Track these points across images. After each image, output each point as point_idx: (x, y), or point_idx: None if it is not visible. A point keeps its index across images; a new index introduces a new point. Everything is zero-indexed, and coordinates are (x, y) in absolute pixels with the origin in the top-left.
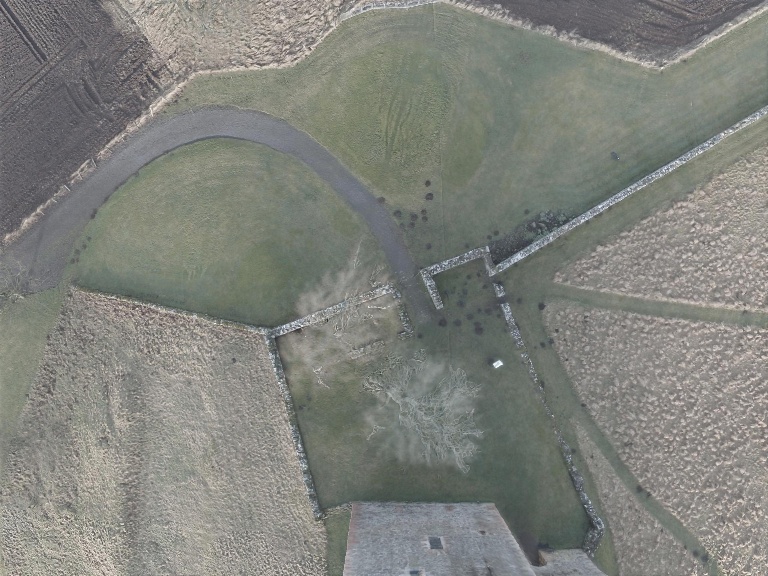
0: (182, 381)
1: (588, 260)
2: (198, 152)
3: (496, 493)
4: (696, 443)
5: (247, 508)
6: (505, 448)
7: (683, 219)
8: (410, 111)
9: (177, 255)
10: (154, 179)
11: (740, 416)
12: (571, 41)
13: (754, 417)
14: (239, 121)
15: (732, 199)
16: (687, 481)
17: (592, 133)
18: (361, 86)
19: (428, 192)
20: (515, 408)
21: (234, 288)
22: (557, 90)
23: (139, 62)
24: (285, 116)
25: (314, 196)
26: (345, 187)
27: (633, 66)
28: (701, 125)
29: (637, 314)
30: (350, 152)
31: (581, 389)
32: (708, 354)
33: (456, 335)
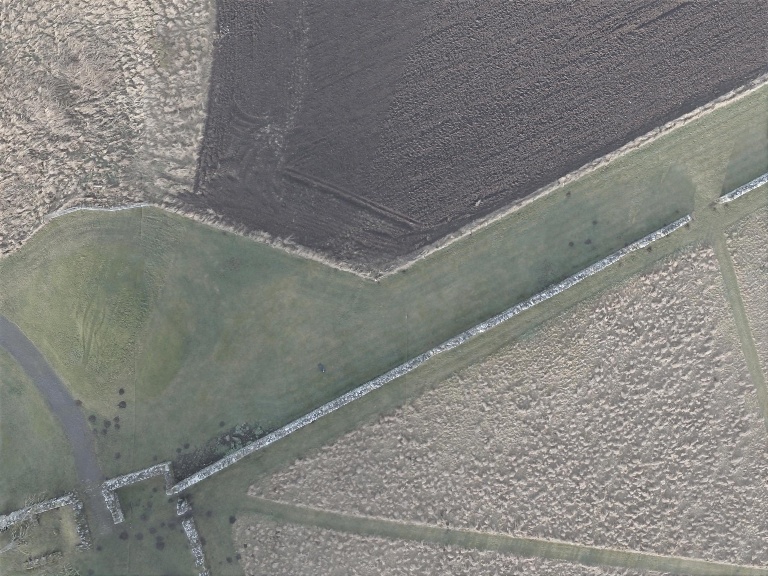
0: None
1: (286, 473)
2: None
3: None
4: None
5: None
6: None
7: (390, 433)
8: (103, 320)
9: None
10: None
11: None
12: (284, 249)
13: None
14: None
15: (442, 415)
16: None
17: (300, 343)
18: (63, 288)
19: (121, 400)
20: None
21: None
22: (266, 299)
23: None
24: None
25: (19, 390)
26: (47, 385)
27: (349, 275)
28: (414, 339)
29: (332, 531)
30: (52, 351)
31: None
32: (404, 574)
33: (137, 549)
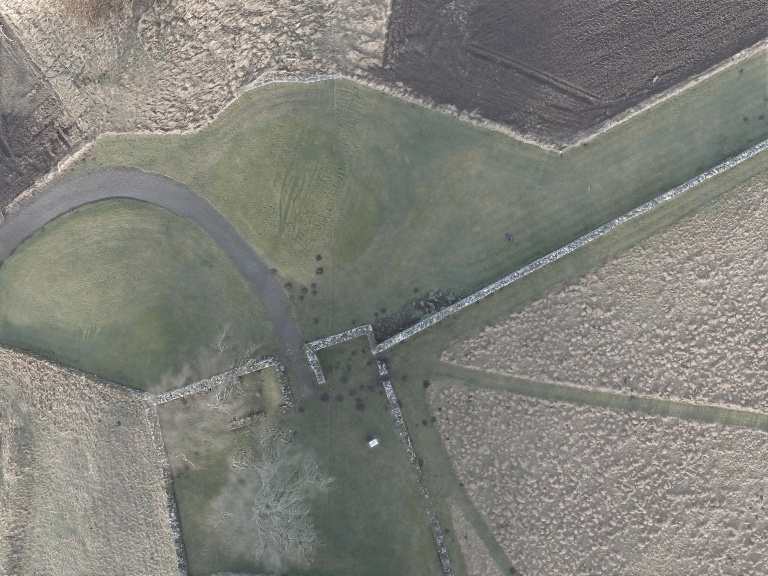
0: (71, 439)
1: (476, 340)
2: (101, 212)
3: (364, 571)
4: (573, 527)
5: (121, 571)
6: (376, 526)
7: (575, 302)
8: (303, 187)
9: (74, 313)
10: (58, 235)
11: (620, 501)
12: (471, 121)
13: (634, 503)
14: (142, 183)
15: (625, 284)
16: (562, 565)
17: (487, 213)
18: (258, 158)
19: (318, 266)
20: (390, 487)
21: (124, 351)
22: (454, 169)
23: (51, 118)
24: (187, 181)
25: (210, 262)
26: (240, 256)
27: (533, 148)
28: (597, 210)
29: (522, 396)
30: (246, 222)
31: (460, 469)
32: (592, 438)
33: (337, 410)
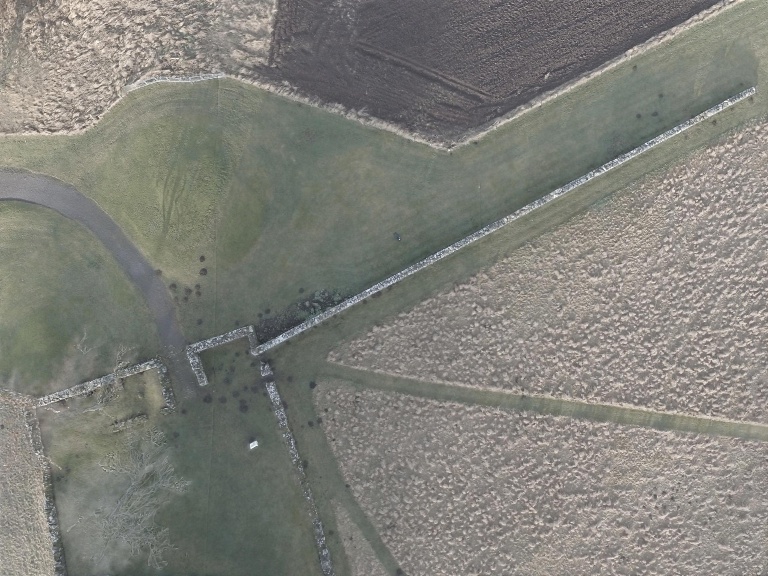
0: None
1: (364, 340)
2: None
3: (243, 574)
4: (462, 527)
5: (2, 575)
6: (257, 528)
7: (465, 302)
8: (184, 187)
9: None
10: None
11: (511, 501)
12: (358, 120)
13: (525, 503)
14: (31, 185)
15: (516, 283)
16: (449, 565)
17: (375, 213)
18: (142, 158)
19: (202, 267)
20: (271, 488)
21: (9, 354)
22: (341, 169)
23: None
24: (74, 182)
25: (97, 264)
26: (126, 257)
27: (422, 146)
28: (487, 208)
29: (410, 396)
30: (131, 223)
31: (346, 470)
32: (481, 438)
33: (220, 412)
